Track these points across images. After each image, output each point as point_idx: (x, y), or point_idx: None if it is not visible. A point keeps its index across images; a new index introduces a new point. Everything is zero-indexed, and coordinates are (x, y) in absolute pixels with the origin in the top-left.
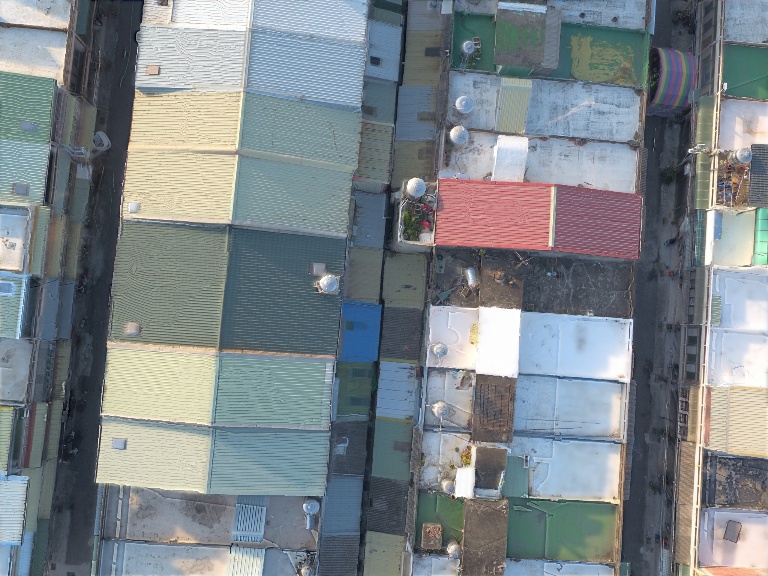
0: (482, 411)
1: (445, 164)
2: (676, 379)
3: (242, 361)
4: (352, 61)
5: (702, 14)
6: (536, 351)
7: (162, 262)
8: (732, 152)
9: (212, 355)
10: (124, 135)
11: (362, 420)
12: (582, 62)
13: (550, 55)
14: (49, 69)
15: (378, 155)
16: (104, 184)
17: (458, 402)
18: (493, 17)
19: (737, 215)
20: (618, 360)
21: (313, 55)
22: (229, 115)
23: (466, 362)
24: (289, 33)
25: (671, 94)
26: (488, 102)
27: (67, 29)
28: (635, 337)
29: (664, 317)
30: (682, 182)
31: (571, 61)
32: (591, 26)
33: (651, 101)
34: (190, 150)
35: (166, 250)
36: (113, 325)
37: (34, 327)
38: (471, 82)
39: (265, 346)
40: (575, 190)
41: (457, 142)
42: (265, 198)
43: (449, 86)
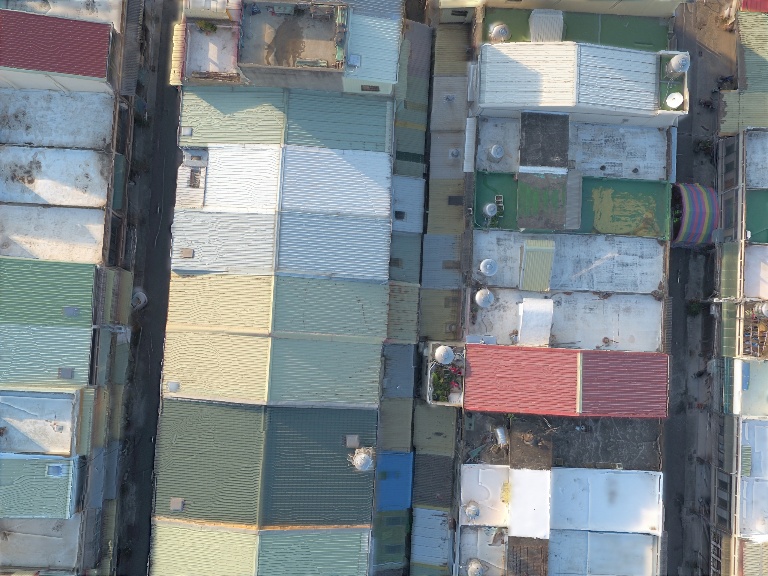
0: (515, 573)
1: (471, 322)
2: (707, 518)
3: (281, 540)
4: (378, 236)
5: (723, 153)
6: (567, 505)
7: (200, 429)
8: (758, 304)
9: (252, 534)
10: (160, 290)
11: (397, 567)
12: (604, 214)
13: (572, 216)
14: (88, 246)
15: (406, 316)
16: (142, 345)
17: (491, 558)
18: (515, 175)
19: (765, 362)
20: (649, 512)
21: (340, 233)
22: (261, 298)
23: (498, 518)
24: (317, 212)
25: (694, 233)
26: (512, 259)
27: (104, 209)
28: (665, 471)
29: (694, 449)
30: (708, 319)
31: (593, 214)
32: (612, 179)
33: (674, 239)
34: (225, 332)
35: (204, 417)
36: (157, 503)
37: (82, 502)
38: (495, 239)
39: (302, 522)
40: (601, 354)
41: (483, 305)
42: (298, 377)
43: (473, 244)
